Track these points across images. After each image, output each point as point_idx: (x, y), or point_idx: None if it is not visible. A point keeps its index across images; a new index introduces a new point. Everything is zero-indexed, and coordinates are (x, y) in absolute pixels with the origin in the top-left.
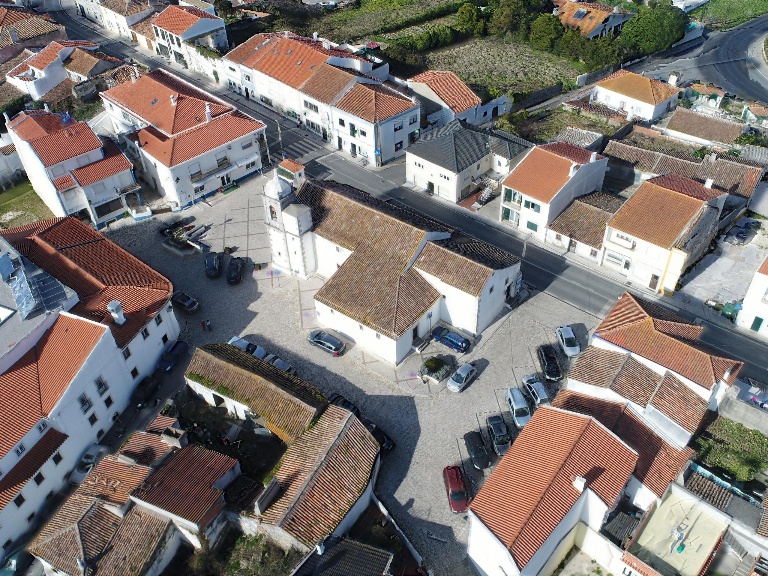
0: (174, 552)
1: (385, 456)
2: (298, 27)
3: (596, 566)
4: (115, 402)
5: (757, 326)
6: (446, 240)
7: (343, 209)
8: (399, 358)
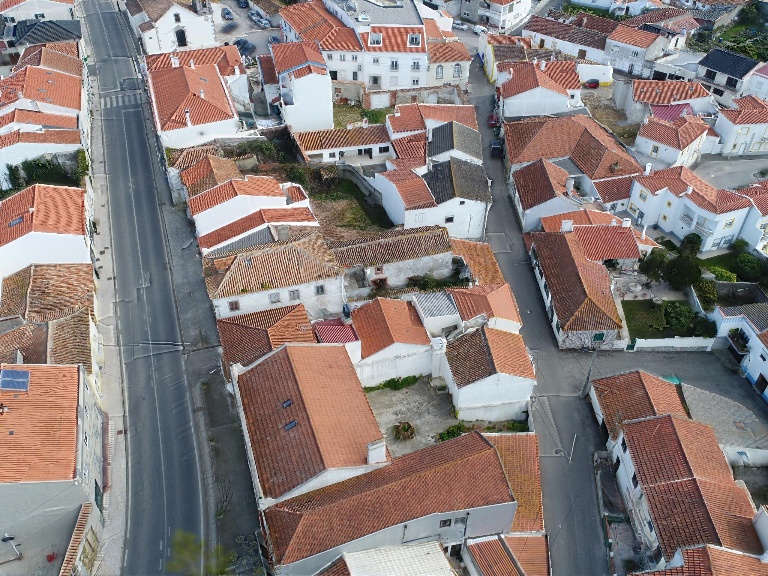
0: None
1: None
2: None
3: None
4: None
5: None
6: None
7: None
8: None
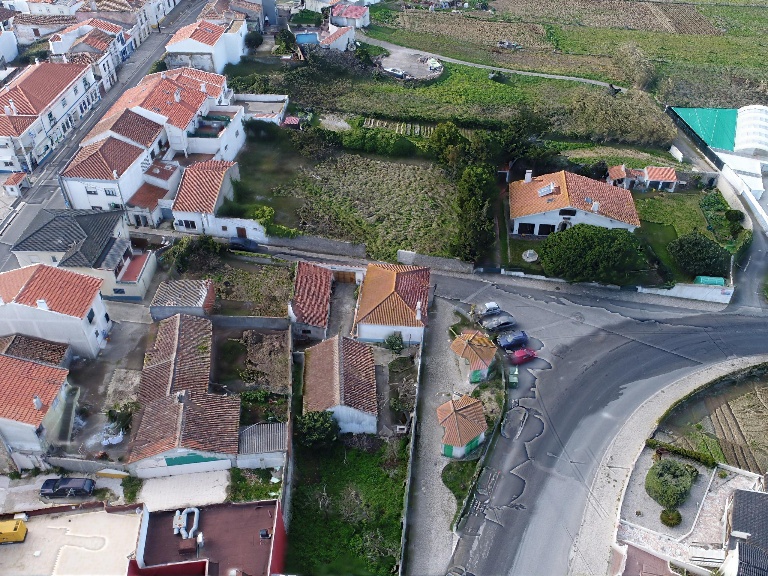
0: None
1: None
2: (314, 80)
3: None
4: None
5: None
6: None
7: None
8: None
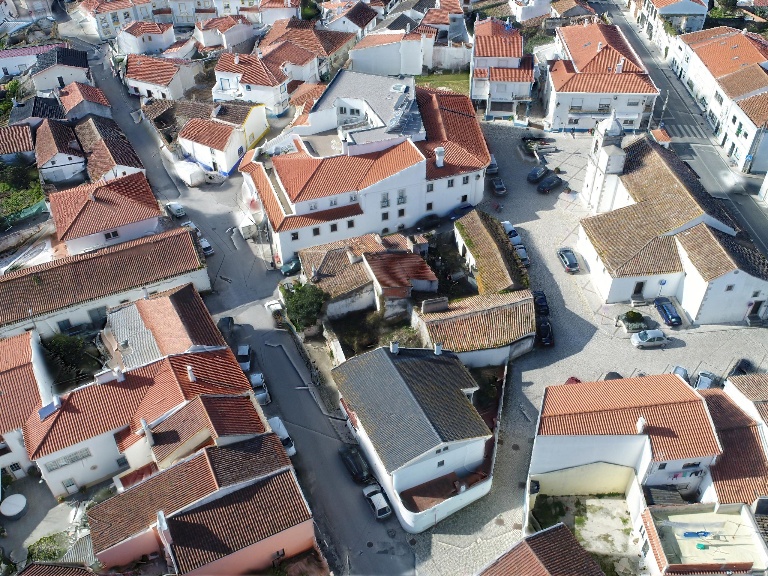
0: (366, 306)
1: (540, 348)
2: None
3: (627, 517)
4: (406, 216)
5: None
6: (726, 234)
7: (655, 169)
8: (612, 298)
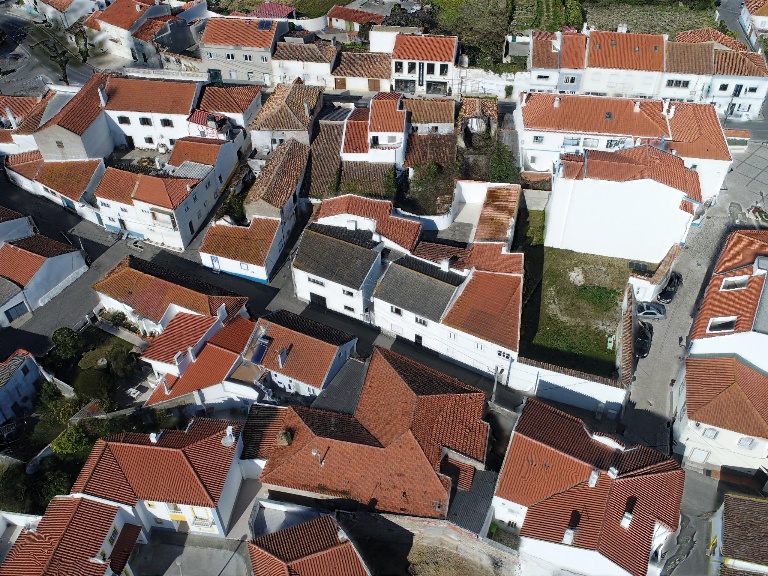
0: None
1: None
2: (450, 34)
3: None
4: None
5: None
6: None
7: None
8: None
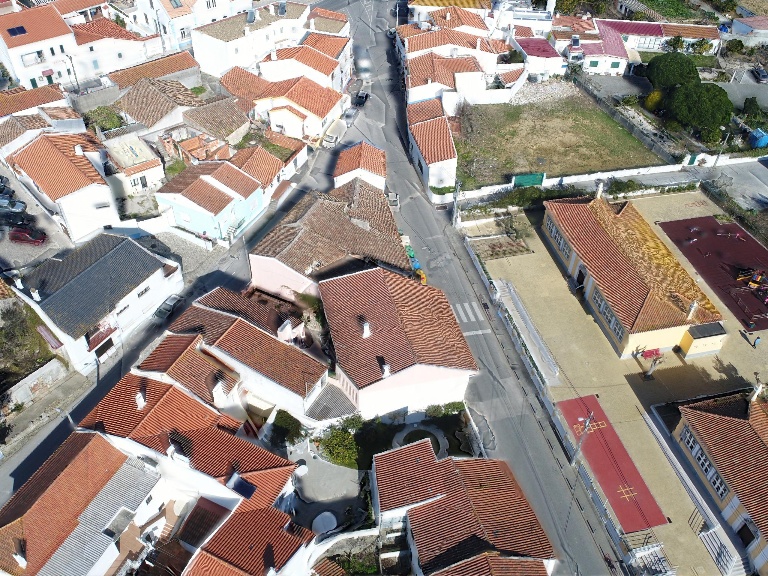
0: None
1: None
2: None
3: (121, 199)
4: None
5: (36, 86)
6: None
7: None
8: None
